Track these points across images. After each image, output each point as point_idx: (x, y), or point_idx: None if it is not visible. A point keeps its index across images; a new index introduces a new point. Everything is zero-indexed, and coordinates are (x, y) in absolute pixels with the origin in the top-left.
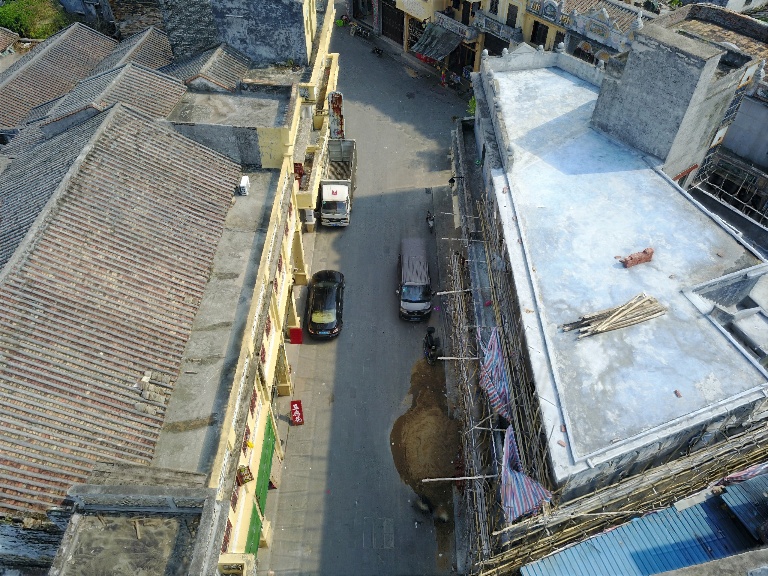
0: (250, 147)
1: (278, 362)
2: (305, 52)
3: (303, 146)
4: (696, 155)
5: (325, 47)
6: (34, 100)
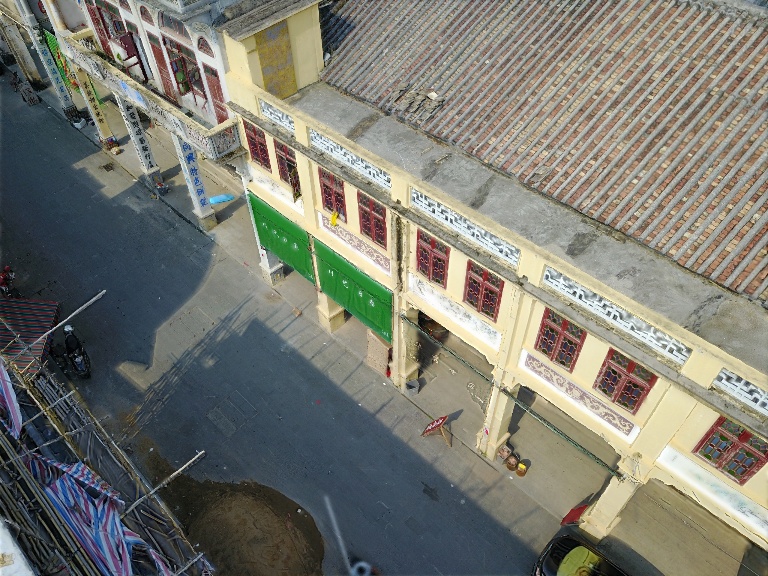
0: None
1: None
2: None
3: None
4: None
5: None
6: None
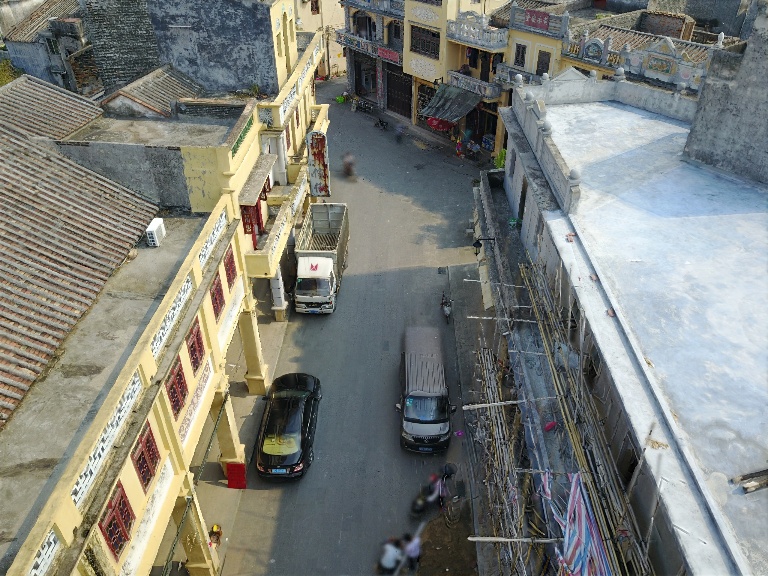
0: (172, 179)
1: None
2: (275, 75)
3: (258, 184)
4: None
5: (305, 78)
6: None
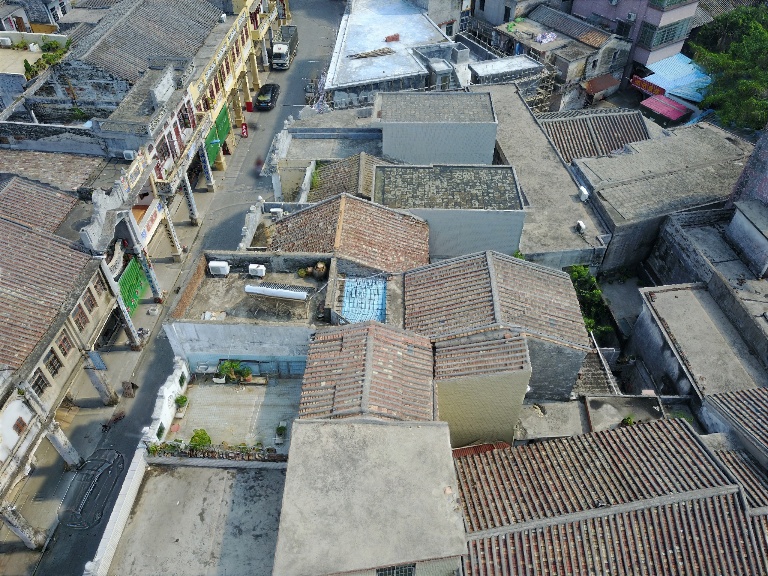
0: (228, 2)
1: (234, 95)
2: None
3: (255, 6)
4: (453, 13)
5: None
6: (116, 1)
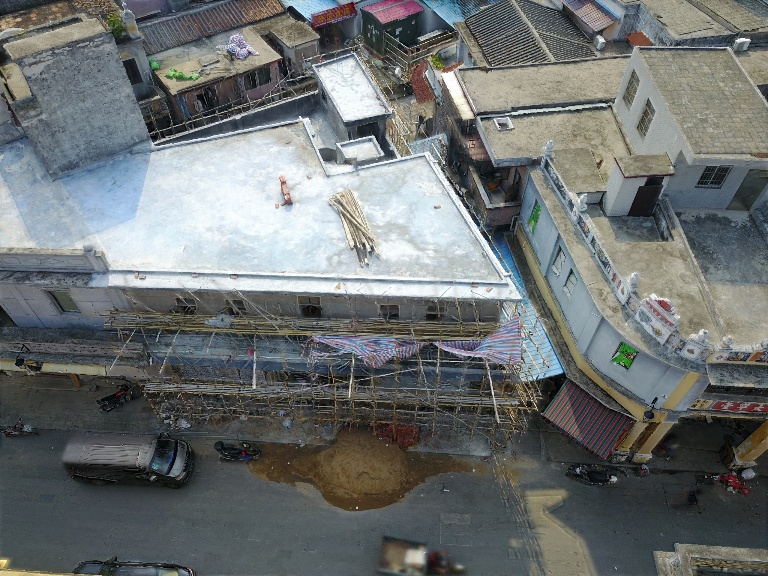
0: None
1: None
2: None
3: None
4: None
5: None
6: None
